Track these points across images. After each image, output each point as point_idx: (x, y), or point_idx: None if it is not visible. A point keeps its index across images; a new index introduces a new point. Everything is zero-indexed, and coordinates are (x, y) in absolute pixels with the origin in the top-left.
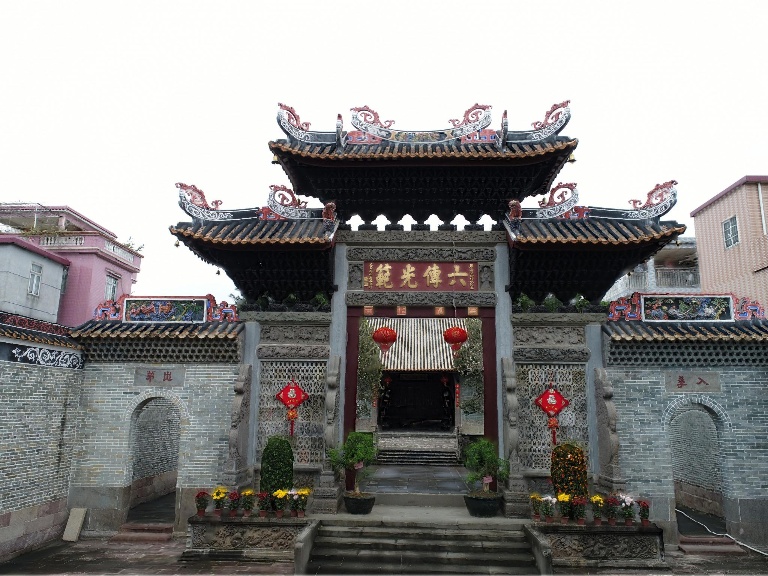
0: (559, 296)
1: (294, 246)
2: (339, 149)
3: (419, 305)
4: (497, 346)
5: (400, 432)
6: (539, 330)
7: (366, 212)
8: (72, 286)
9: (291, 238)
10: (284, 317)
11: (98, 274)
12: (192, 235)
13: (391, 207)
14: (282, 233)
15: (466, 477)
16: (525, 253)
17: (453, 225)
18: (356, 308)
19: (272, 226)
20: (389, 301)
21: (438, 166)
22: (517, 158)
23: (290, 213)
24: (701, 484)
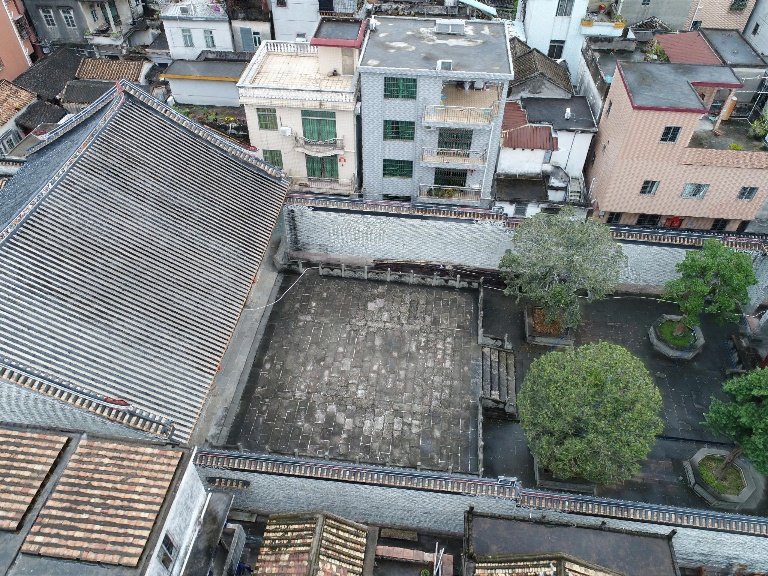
0: None
1: None
2: None
3: None
4: None
5: None
6: None
7: None
8: None
9: None
10: None
11: None
12: None
13: None
14: None
15: None
16: None
17: None
18: None
19: None
20: None
21: None
22: None
23: None
24: None
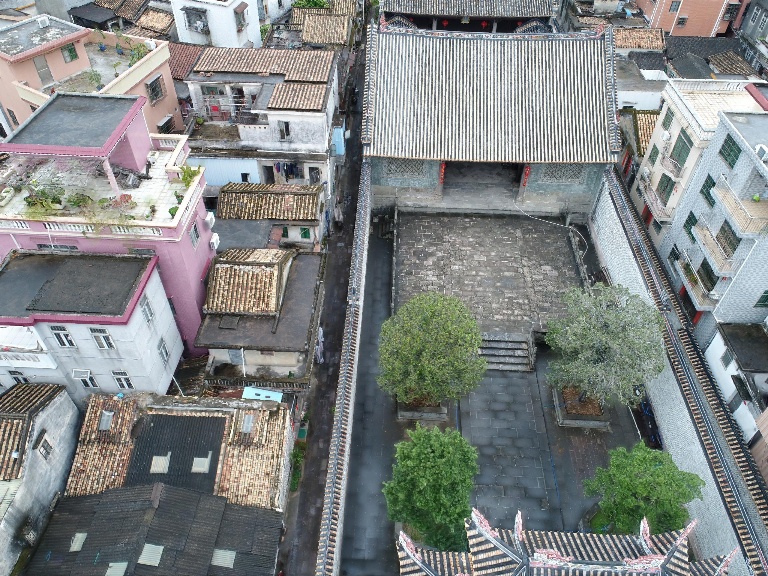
0: None
1: None
2: None
3: None
4: None
5: (462, 188)
6: None
7: None
8: (166, 266)
9: None
10: None
11: (185, 246)
12: None
13: None
14: None
15: (540, 434)
16: None
17: None
18: None
19: None
20: None
21: None
22: None
23: None
24: (703, 553)
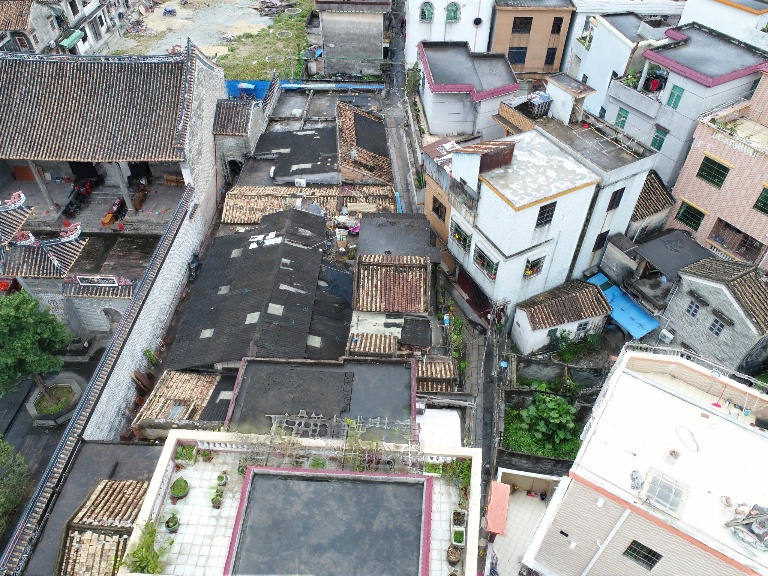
0: None
1: None
2: None
3: None
4: None
5: None
6: None
7: None
8: None
9: None
10: None
11: None
12: None
13: None
14: None
15: None
16: None
17: None
18: None
19: None
20: None
21: None
22: None
23: None
24: None
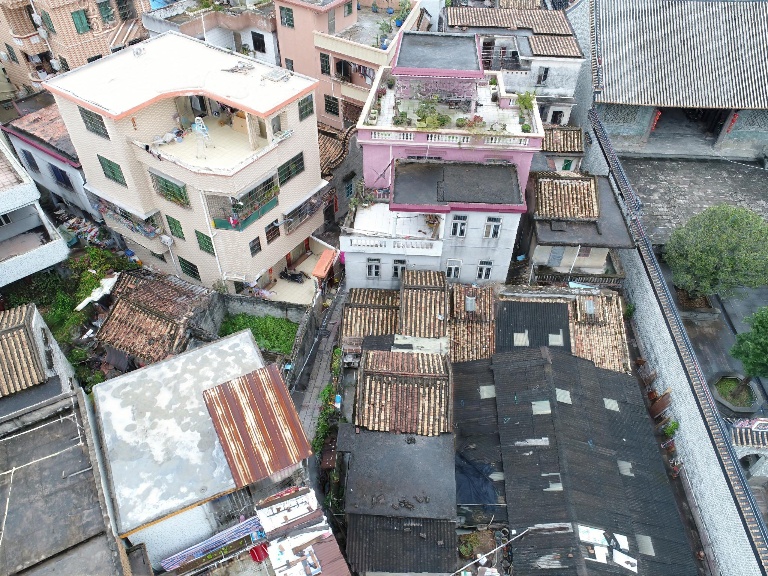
0: None
1: None
2: None
3: None
4: None
5: (660, 137)
6: None
7: None
8: None
9: None
10: None
11: None
12: None
13: None
14: None
15: None
16: None
17: None
18: None
19: None
20: None
21: None
22: None
23: None
24: None
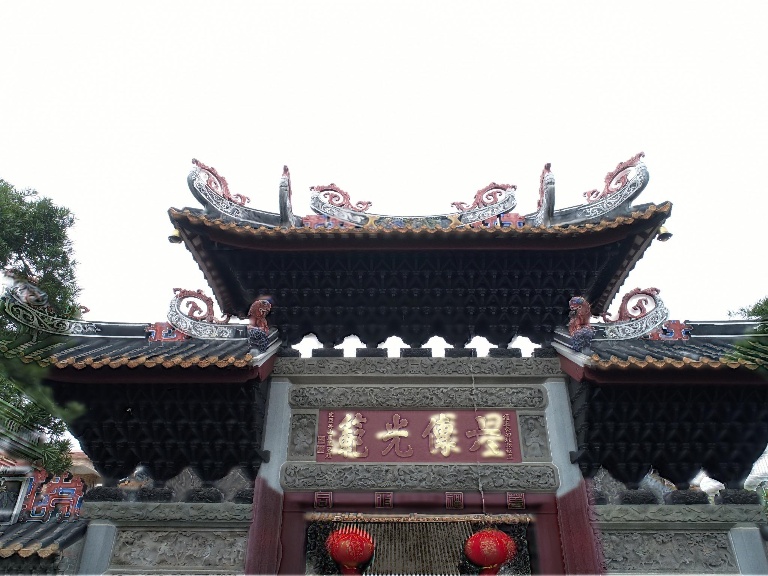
0: (668, 472)
1: (190, 374)
2: (284, 225)
3: (416, 489)
4: (569, 572)
5: None
6: (643, 538)
7: (326, 328)
8: None
9: (185, 359)
10: (163, 513)
11: None
12: (3, 352)
13: (367, 319)
14: (174, 354)
15: None
16: (604, 389)
17: (470, 349)
18: (300, 495)
19: (165, 348)
20: (361, 481)
21: (444, 249)
22: (572, 234)
23: (201, 330)
24: None
